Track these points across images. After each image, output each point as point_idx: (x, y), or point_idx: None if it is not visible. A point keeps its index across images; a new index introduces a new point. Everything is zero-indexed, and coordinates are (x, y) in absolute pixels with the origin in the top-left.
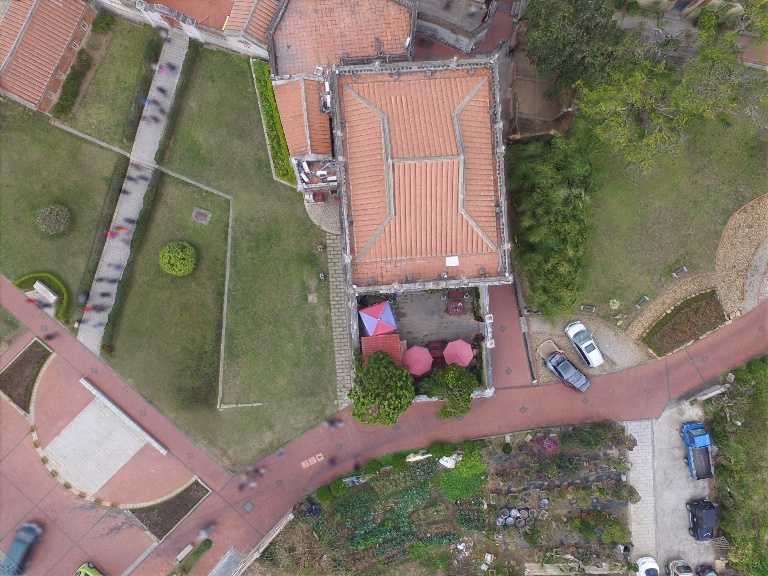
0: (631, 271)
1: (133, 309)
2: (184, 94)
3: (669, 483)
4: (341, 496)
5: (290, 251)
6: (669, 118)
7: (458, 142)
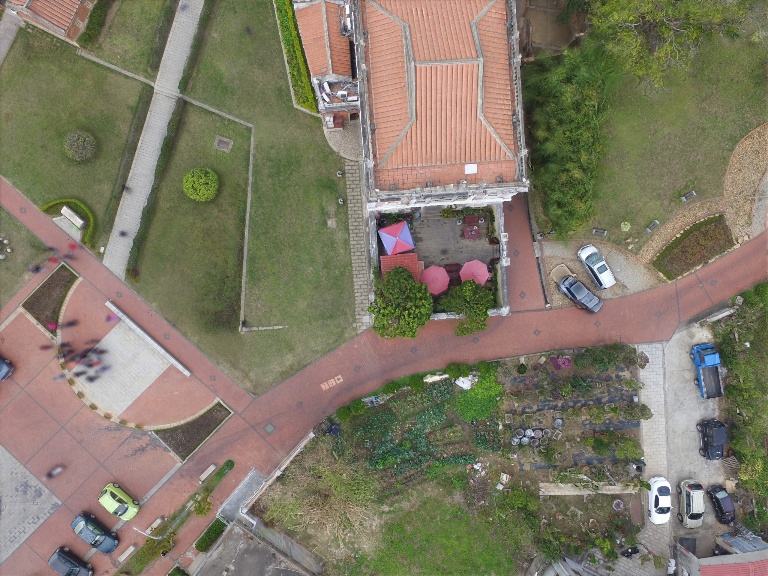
0: (642, 196)
1: (157, 235)
2: (207, 25)
3: (680, 405)
4: (360, 417)
5: (310, 177)
6: (679, 32)
7: (477, 47)
